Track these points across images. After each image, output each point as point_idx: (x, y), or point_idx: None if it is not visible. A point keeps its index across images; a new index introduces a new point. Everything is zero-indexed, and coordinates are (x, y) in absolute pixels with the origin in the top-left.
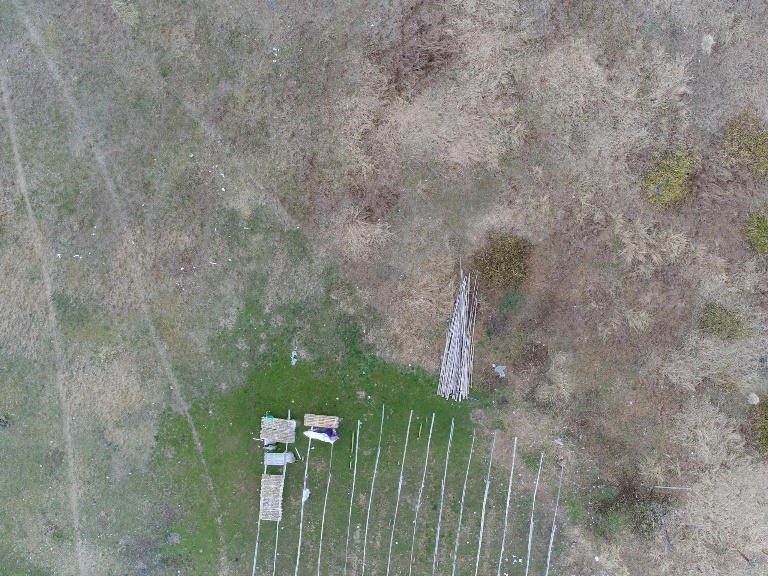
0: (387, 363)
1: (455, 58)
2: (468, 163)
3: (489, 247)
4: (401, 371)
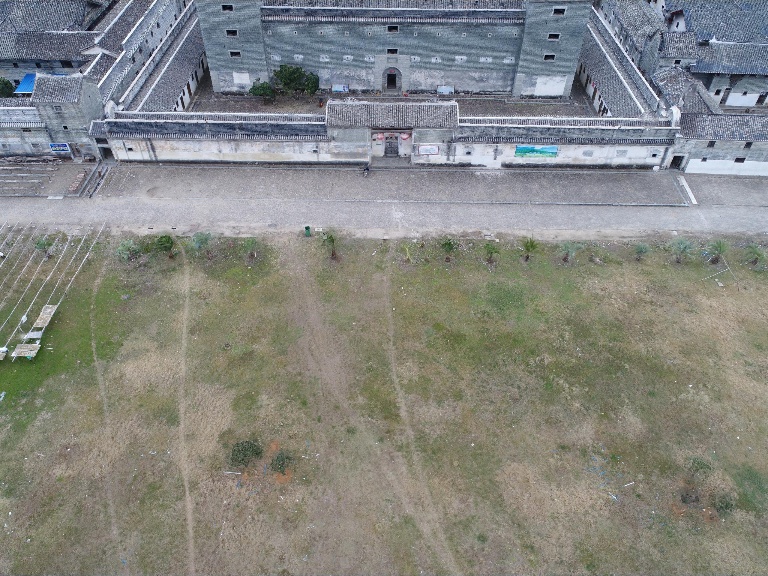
0: None
1: None
2: None
3: None
4: None
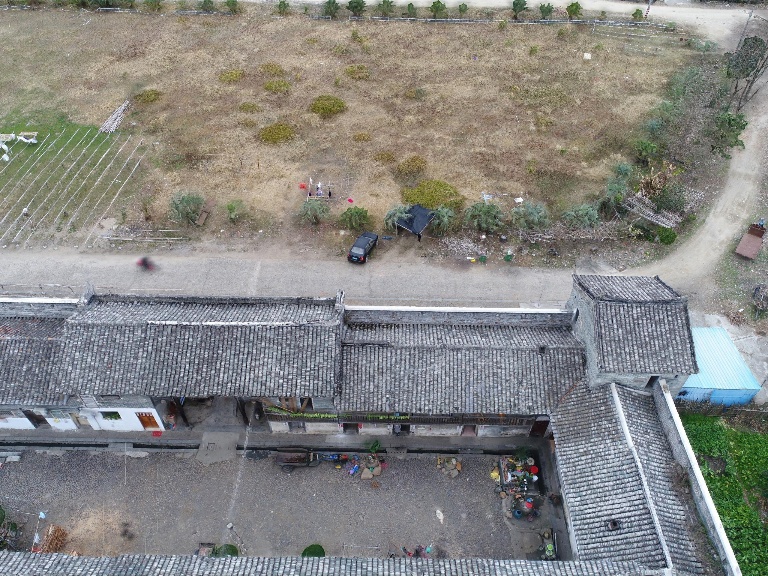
0: (76, 124)
1: (147, 54)
2: (142, 75)
3: None
4: (83, 126)
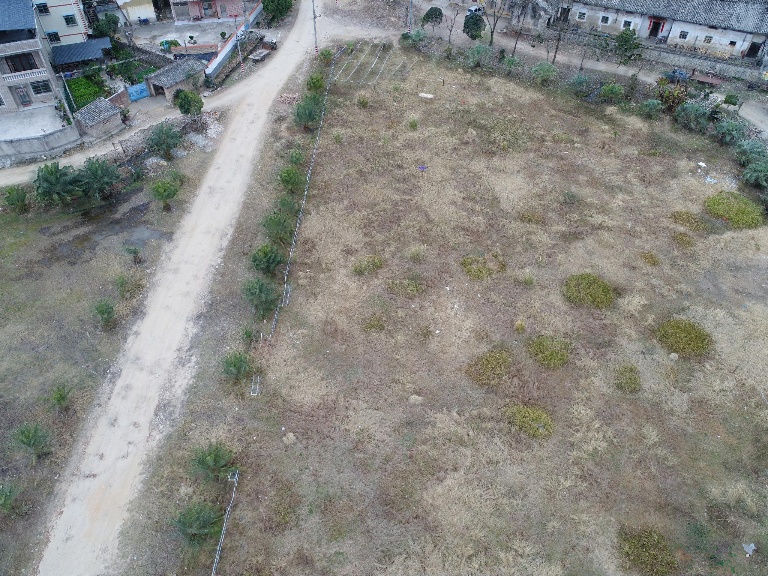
0: None
1: None
2: None
3: (638, 569)
4: None
